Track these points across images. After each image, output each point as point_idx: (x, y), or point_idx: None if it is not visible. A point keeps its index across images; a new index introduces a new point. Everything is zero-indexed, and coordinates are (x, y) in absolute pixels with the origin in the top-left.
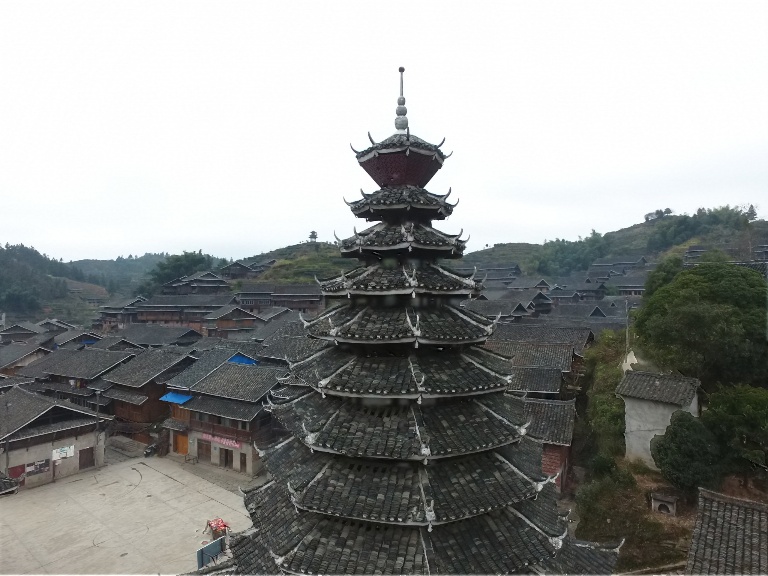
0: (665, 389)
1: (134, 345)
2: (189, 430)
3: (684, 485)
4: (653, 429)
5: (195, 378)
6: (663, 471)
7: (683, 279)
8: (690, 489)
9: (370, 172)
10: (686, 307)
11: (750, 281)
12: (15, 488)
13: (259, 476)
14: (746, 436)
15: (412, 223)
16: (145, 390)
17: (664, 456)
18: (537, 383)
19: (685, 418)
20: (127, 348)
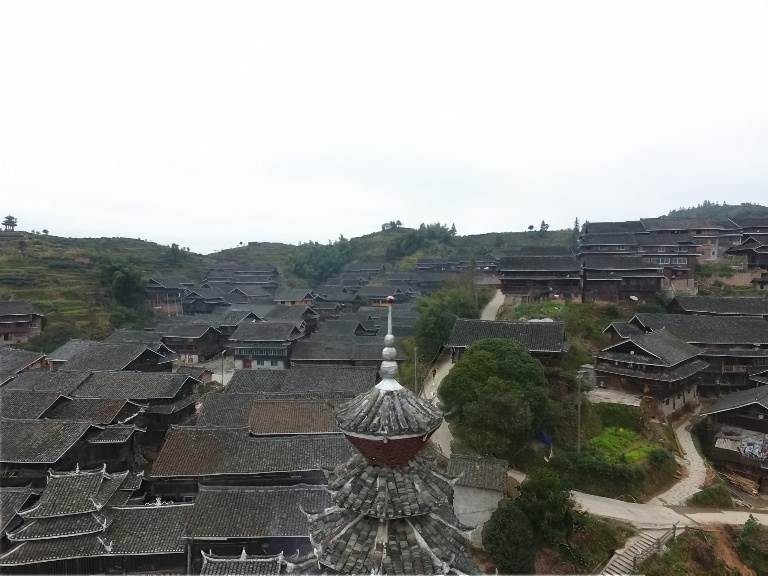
0: (485, 474)
1: None
2: None
3: (513, 571)
4: (477, 511)
5: None
6: (495, 559)
7: (478, 355)
8: (516, 572)
9: (359, 445)
10: (496, 397)
11: (523, 358)
12: None
13: None
14: (552, 519)
15: None
16: None
17: (495, 545)
18: None
19: (510, 509)
20: None
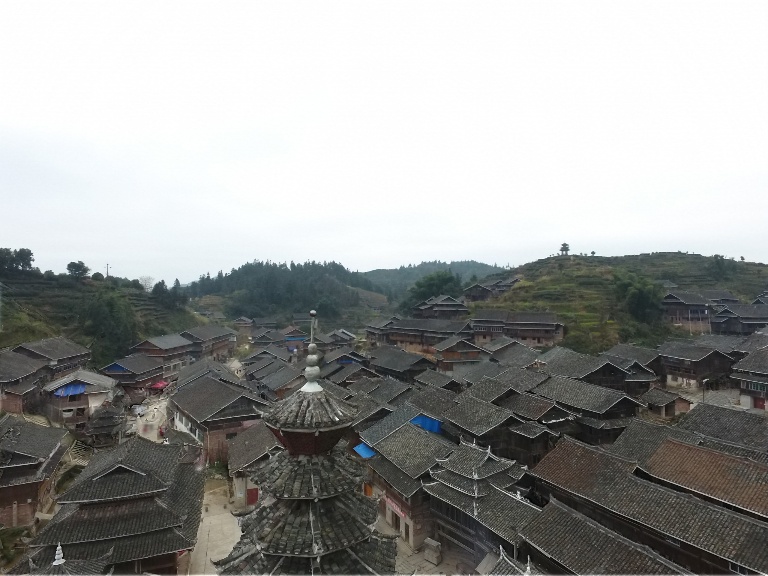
0: None
1: (372, 372)
2: (372, 484)
3: None
4: None
5: (379, 435)
6: None
7: None
8: None
9: None
10: None
11: None
12: (192, 547)
13: (420, 552)
14: None
15: (254, 534)
16: (347, 436)
17: None
18: (765, 558)
19: None
20: (364, 376)
